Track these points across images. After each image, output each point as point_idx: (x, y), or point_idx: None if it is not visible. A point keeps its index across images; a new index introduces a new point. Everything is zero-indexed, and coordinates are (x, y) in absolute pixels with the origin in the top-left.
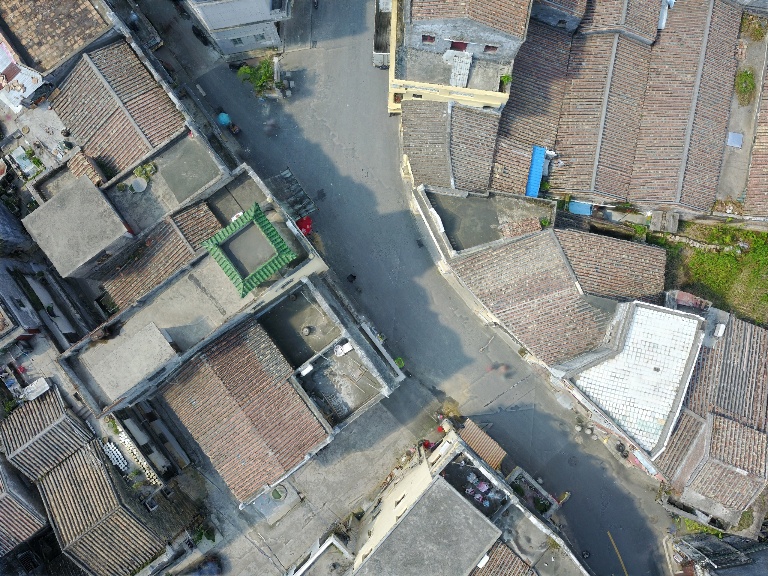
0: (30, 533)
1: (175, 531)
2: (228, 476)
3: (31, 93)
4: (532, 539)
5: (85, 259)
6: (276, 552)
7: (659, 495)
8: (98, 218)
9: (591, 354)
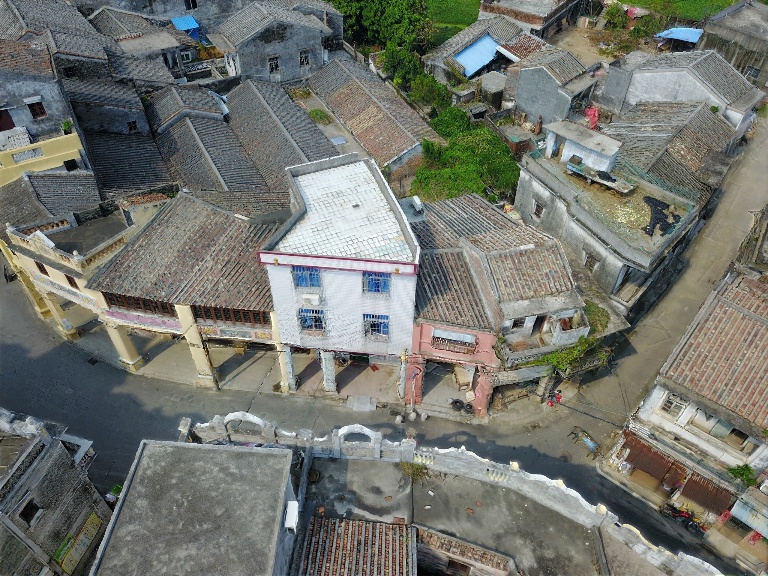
0: None
1: None
2: None
3: None
4: (381, 486)
5: None
6: None
7: (502, 360)
8: None
9: None
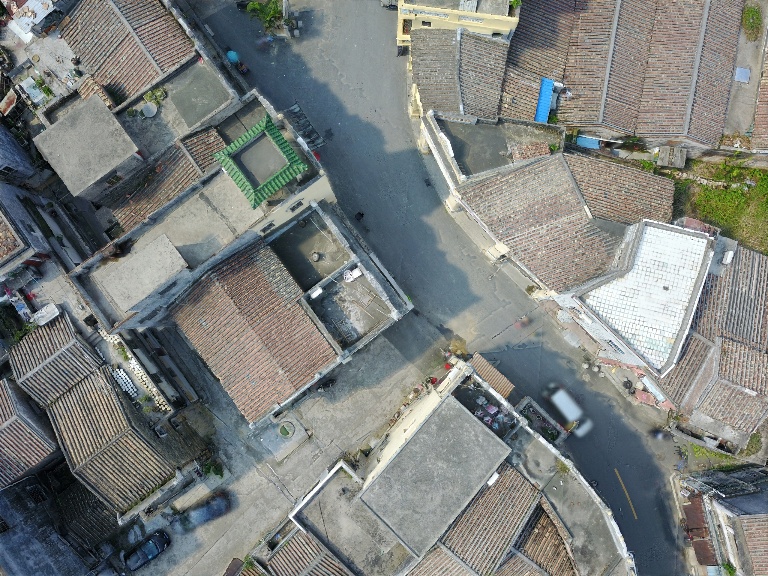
0: (40, 458)
1: (184, 459)
2: (238, 397)
3: (41, 19)
4: (541, 463)
5: (96, 178)
6: (284, 488)
7: (667, 422)
8: (109, 137)
9: (600, 277)
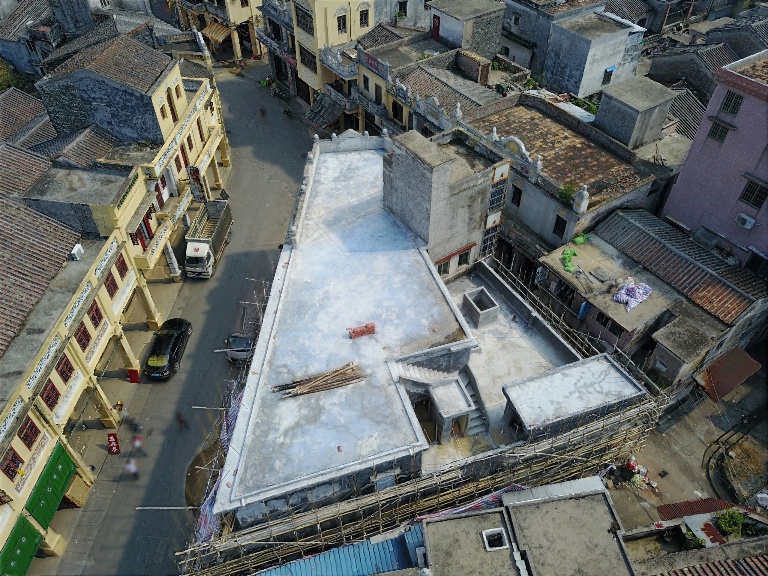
0: None
1: None
2: None
3: None
4: None
5: None
6: None
7: None
8: None
9: None
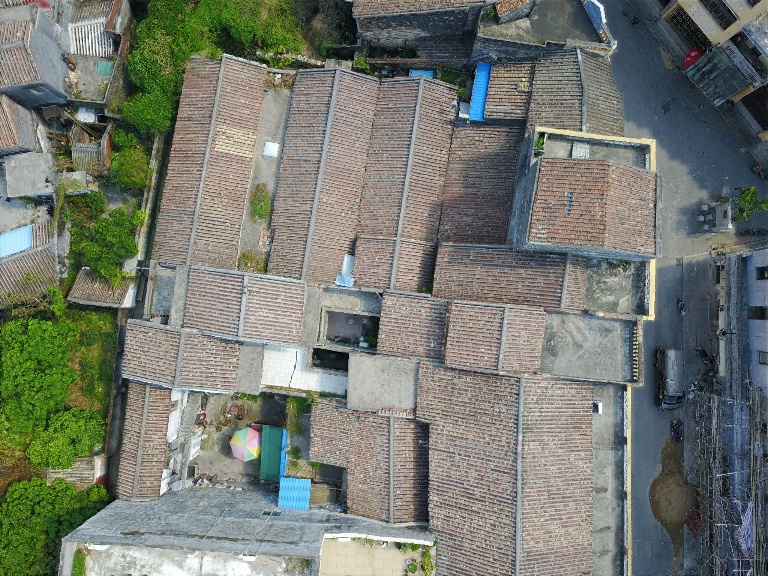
0: None
1: None
2: None
3: None
4: None
5: None
6: None
7: None
8: None
9: None
